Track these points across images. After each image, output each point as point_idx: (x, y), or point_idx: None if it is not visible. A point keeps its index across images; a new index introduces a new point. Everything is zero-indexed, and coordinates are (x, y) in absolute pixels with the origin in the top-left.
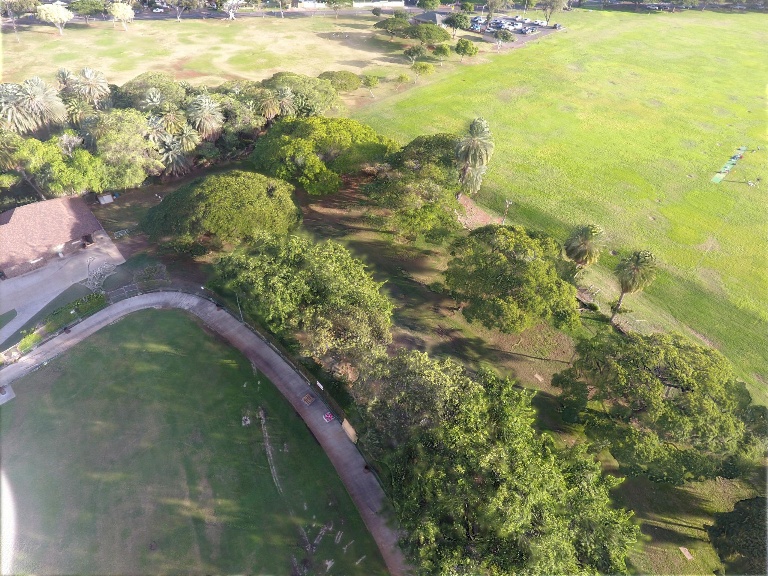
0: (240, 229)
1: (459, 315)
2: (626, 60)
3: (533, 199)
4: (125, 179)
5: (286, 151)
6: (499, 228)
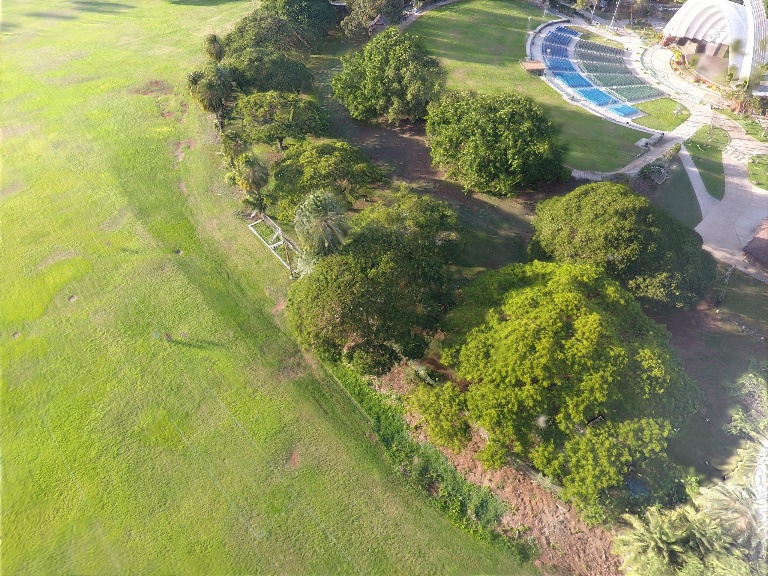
0: None
1: None
2: None
3: (211, 334)
4: None
5: None
6: (329, 170)
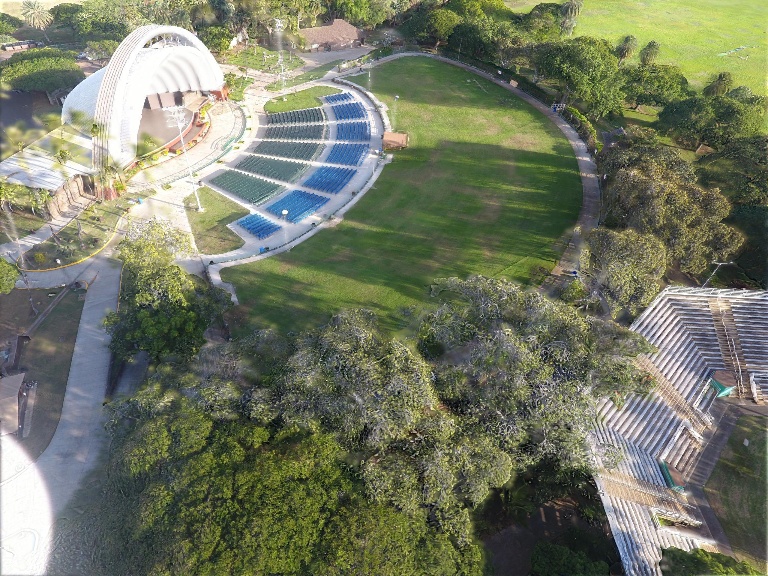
0: (450, 31)
1: (556, 80)
2: (684, 3)
3: None
4: (378, 17)
5: (466, 6)
6: None
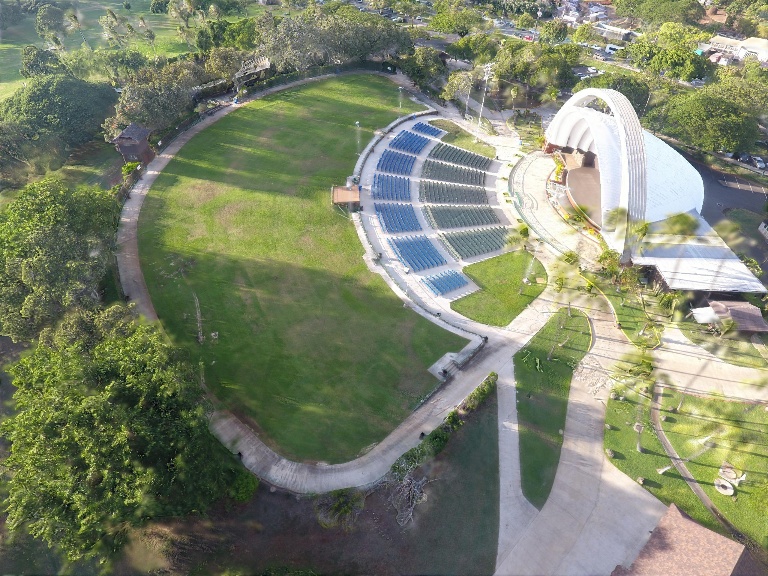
0: None
1: None
2: None
3: None
4: None
5: None
6: None
